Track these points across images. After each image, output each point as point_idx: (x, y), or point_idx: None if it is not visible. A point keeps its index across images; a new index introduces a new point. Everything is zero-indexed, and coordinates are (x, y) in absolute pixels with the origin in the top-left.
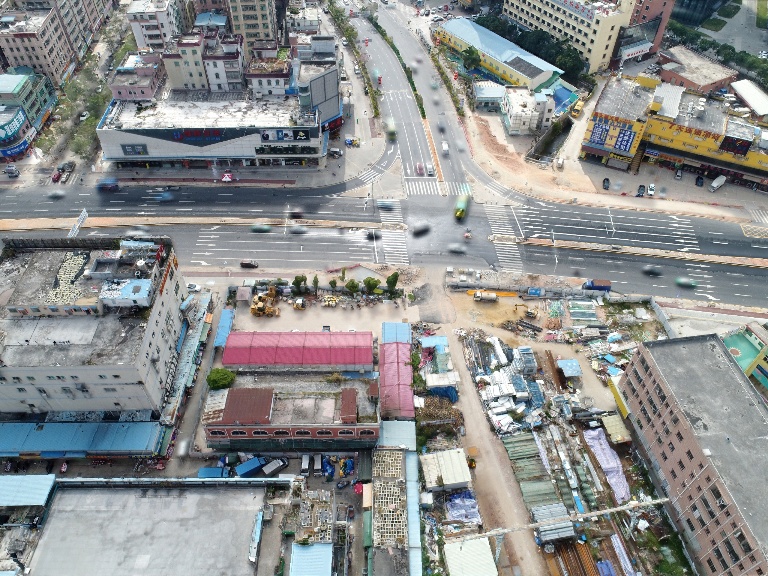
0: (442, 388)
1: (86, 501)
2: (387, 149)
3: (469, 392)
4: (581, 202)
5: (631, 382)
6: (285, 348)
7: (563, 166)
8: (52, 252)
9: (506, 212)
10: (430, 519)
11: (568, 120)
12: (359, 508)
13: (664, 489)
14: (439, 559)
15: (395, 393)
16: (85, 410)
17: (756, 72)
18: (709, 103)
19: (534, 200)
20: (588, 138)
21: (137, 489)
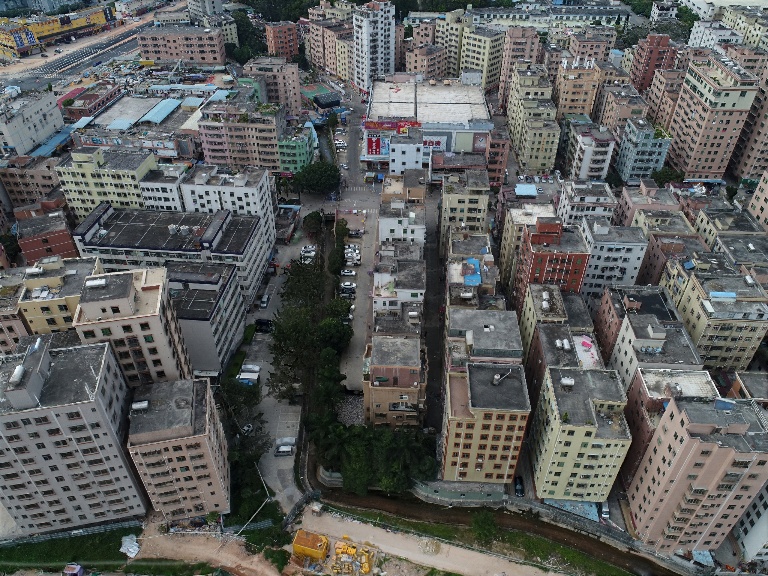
0: None
1: (98, 120)
2: None
3: None
4: (49, 61)
5: None
6: None
7: None
8: None
9: None
10: None
11: None
12: None
13: None
14: None
15: None
16: None
17: (18, 16)
18: None
19: None
20: (16, 45)
21: (102, 113)
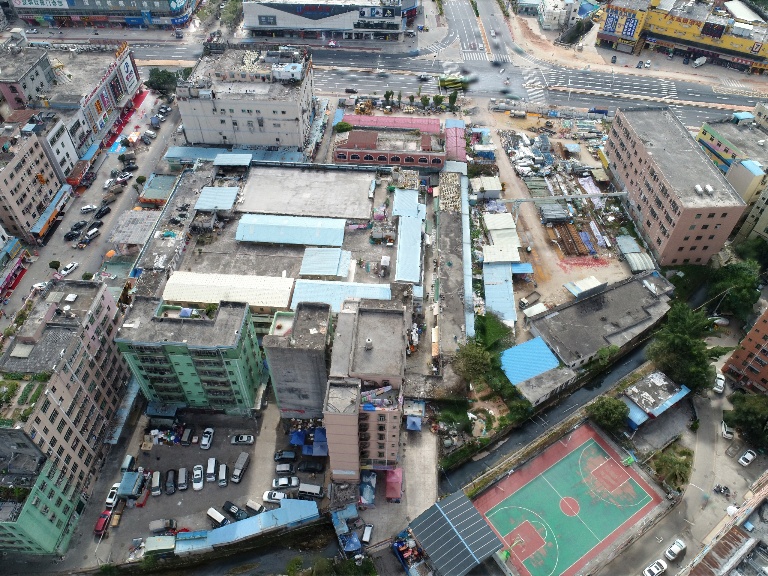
0: (485, 153)
1: (269, 172)
2: (449, 34)
3: (503, 158)
4: (593, 69)
5: (611, 140)
6: (382, 122)
7: (582, 49)
8: (236, 50)
9: (536, 72)
10: (475, 209)
11: (590, 23)
12: (430, 202)
13: (627, 203)
14: (480, 225)
15: (454, 150)
16: (256, 144)
17: None
18: (698, 4)
19: (558, 66)
20: (602, 27)
21: (299, 169)
